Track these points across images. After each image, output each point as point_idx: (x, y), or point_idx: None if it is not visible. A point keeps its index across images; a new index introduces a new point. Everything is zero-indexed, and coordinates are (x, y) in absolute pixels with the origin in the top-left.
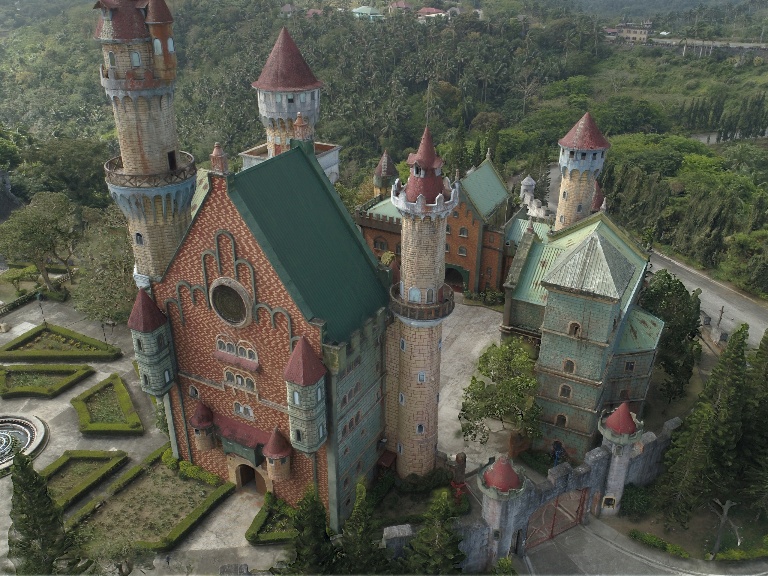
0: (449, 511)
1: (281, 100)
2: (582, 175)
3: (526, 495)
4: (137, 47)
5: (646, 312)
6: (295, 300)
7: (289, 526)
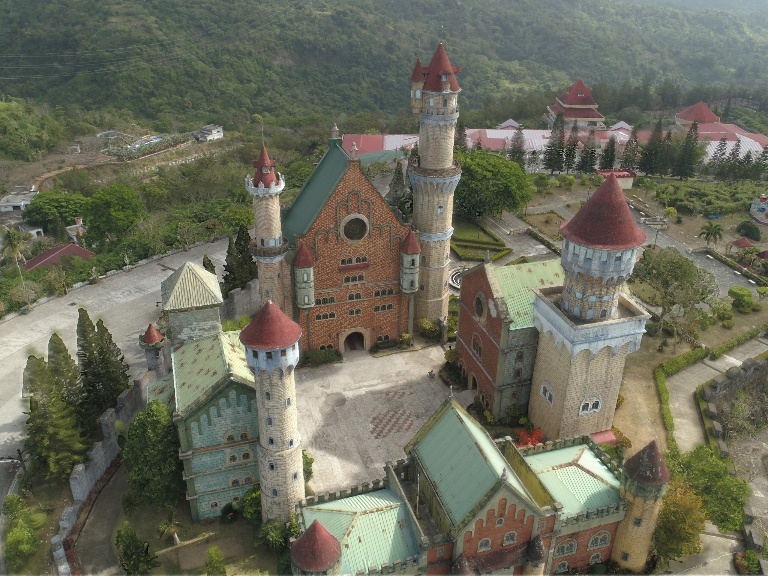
0: None
1: None
2: None
3: None
4: None
5: None
6: None
7: None
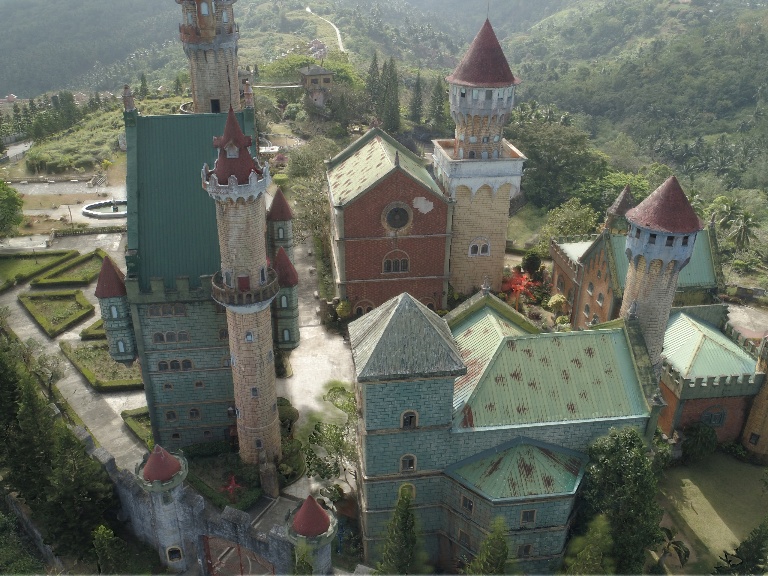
0: (63, 442)
1: (456, 92)
2: (640, 260)
3: (188, 507)
4: (191, 8)
5: (579, 470)
6: (128, 228)
7: None
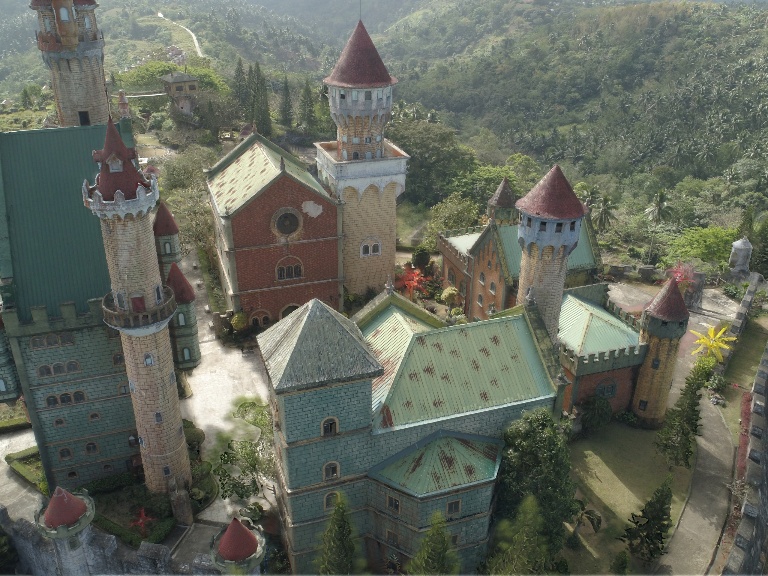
0: None
1: (335, 94)
2: (533, 248)
3: (99, 549)
4: (48, 14)
5: (497, 455)
6: None
7: (42, 469)
